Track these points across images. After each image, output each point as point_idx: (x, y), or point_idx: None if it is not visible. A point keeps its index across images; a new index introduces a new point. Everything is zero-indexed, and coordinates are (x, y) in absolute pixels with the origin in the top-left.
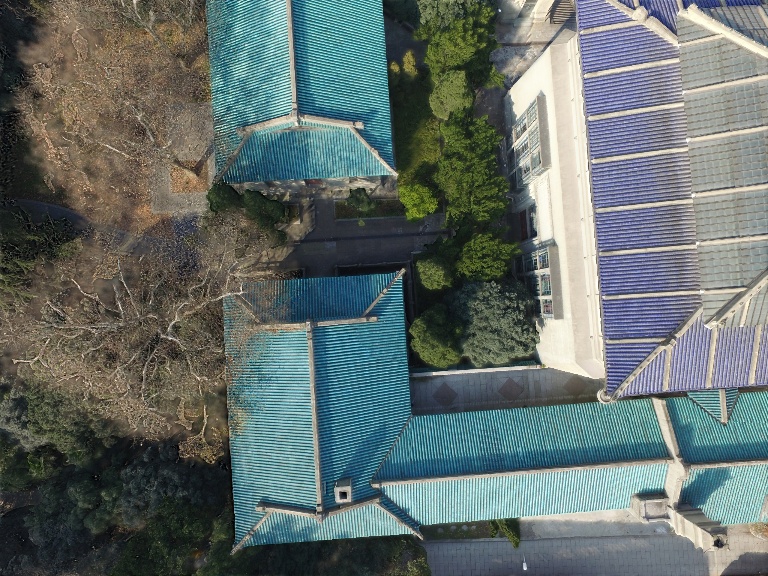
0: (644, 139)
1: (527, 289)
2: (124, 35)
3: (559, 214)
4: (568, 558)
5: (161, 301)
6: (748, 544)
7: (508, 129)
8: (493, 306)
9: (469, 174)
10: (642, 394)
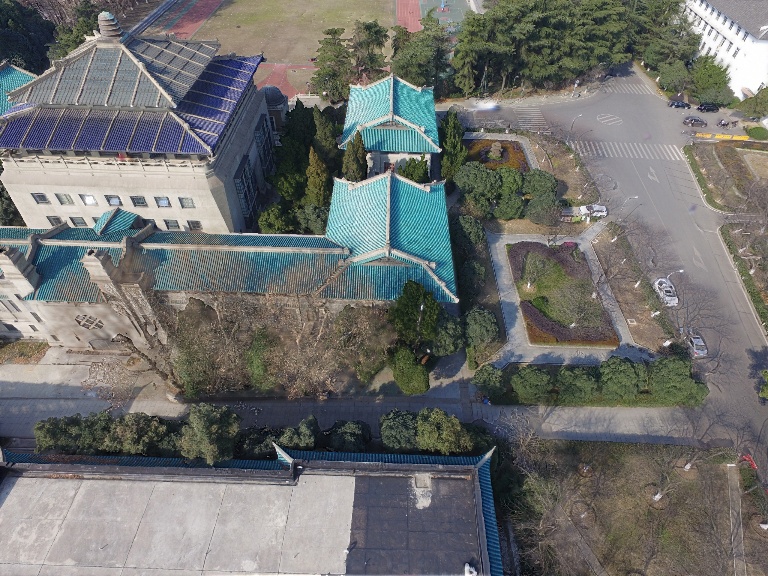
0: None
1: None
2: None
3: None
4: None
5: None
6: (161, 408)
7: None
8: None
9: None
10: None
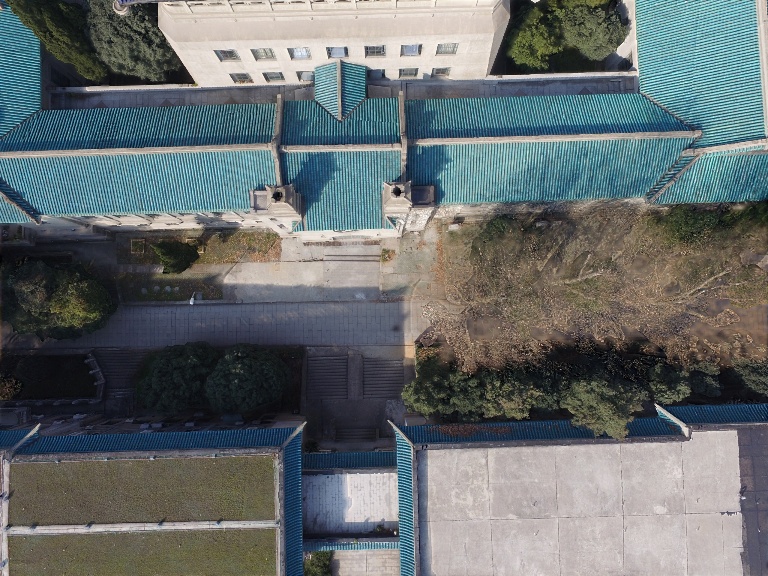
0: None
1: None
2: None
3: None
4: (269, 322)
5: None
6: None
7: None
8: None
9: None
10: (152, 1)
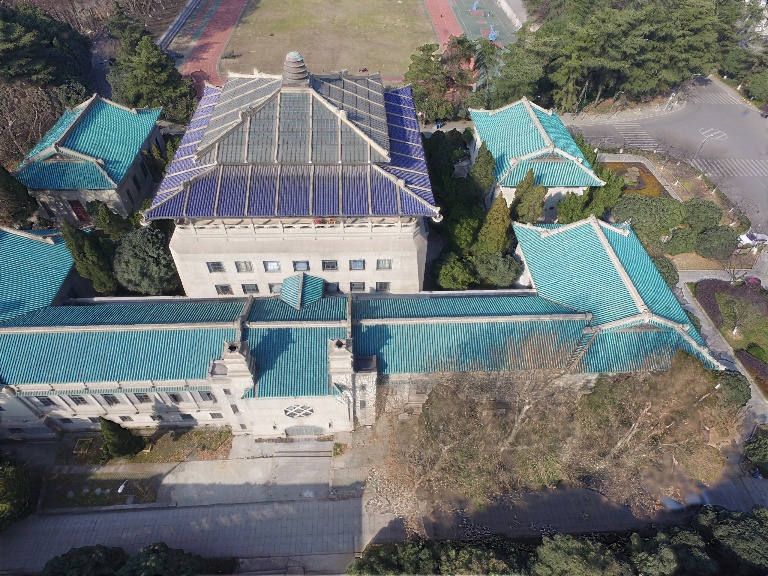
0: None
1: None
2: (14, 163)
3: None
4: (200, 530)
5: None
6: None
7: None
8: None
9: None
10: None
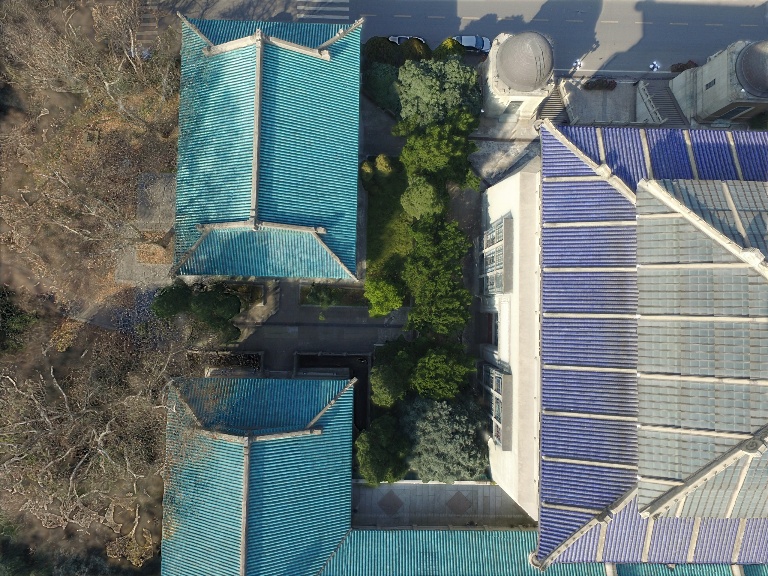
0: (598, 299)
1: (483, 404)
2: (104, 99)
3: (515, 344)
4: None
5: (110, 382)
6: None
7: (483, 227)
8: (441, 429)
9: (432, 283)
10: None
